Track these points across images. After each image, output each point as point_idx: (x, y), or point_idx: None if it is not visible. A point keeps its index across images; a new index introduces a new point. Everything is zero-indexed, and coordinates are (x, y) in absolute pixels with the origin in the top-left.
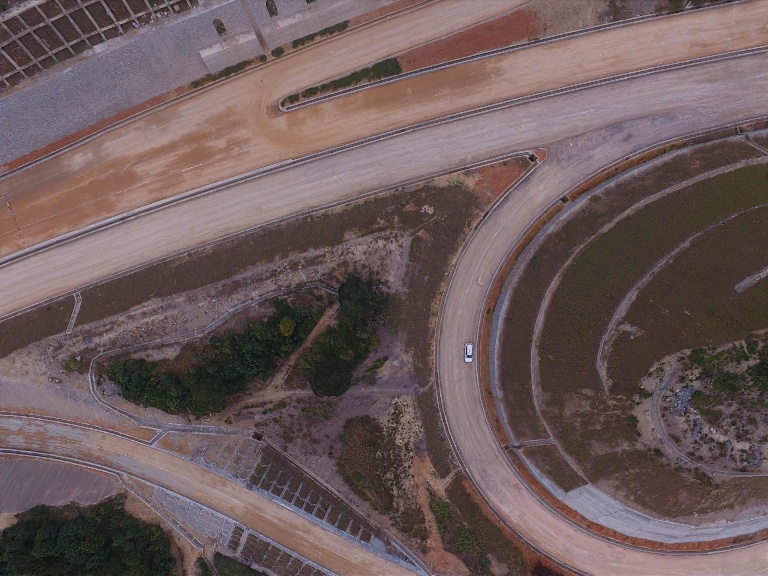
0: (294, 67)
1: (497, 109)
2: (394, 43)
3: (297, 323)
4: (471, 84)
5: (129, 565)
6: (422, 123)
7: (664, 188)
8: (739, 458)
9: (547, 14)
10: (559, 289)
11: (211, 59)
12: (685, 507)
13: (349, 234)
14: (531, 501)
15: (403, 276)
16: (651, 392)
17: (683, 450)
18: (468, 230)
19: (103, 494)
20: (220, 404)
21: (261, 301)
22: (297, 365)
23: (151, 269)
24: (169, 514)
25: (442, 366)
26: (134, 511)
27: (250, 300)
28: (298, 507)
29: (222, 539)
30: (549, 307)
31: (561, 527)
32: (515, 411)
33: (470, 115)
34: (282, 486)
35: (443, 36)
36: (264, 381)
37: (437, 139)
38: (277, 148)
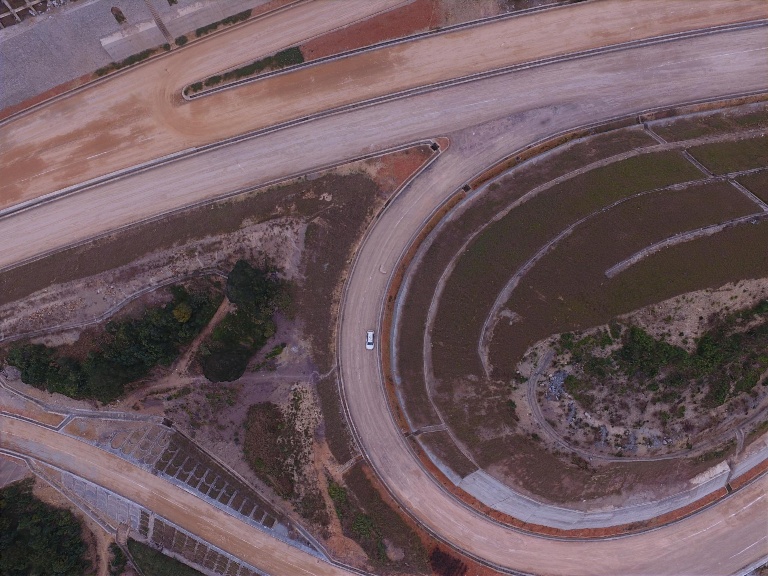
0: (198, 56)
1: (399, 98)
2: (297, 32)
3: (193, 309)
4: (374, 73)
5: (35, 549)
6: (324, 112)
7: (557, 176)
8: (614, 443)
9: (448, 3)
10: (452, 276)
11: (113, 47)
12: (570, 492)
13: (247, 221)
14: (431, 487)
15: (299, 263)
16: (526, 377)
17: (560, 435)
18: (370, 218)
19: (9, 478)
20: (116, 389)
21: (159, 287)
22: (199, 351)
23: (56, 256)
24: (80, 499)
25: (344, 353)
26: (43, 496)
27: (148, 286)
28: (202, 492)
29: (133, 524)
30: (442, 294)
31: (460, 513)
32: (411, 398)
33: (372, 104)
34: (188, 472)
35: (345, 25)
36: (167, 367)
37: (340, 128)
38: (181, 136)
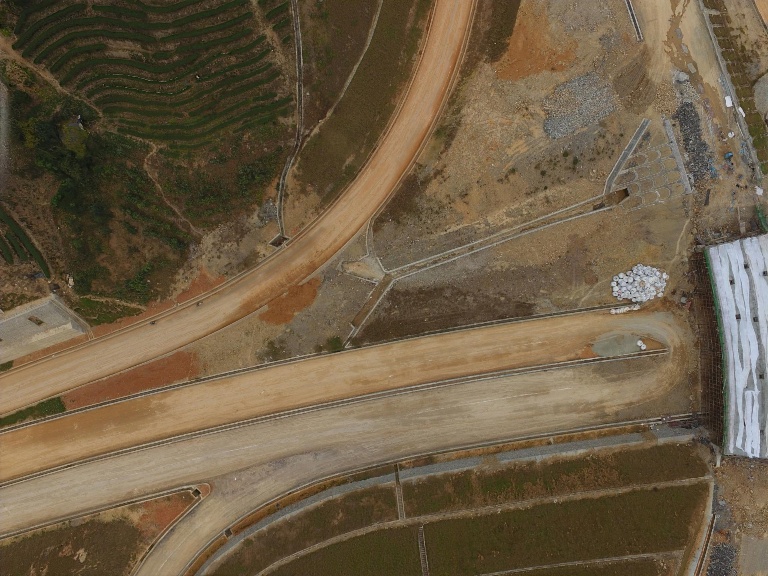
0: None
1: (161, 445)
2: (58, 382)
3: None
4: (136, 420)
5: None
6: (87, 459)
7: (298, 550)
8: None
9: (206, 355)
10: None
11: None
12: None
13: None
14: None
15: None
16: None
17: None
18: (133, 563)
19: None
20: None
21: None
22: None
23: None
24: None
25: None
26: None
27: None
28: None
29: None
30: None
31: None
32: None
33: (134, 451)
34: None
35: (104, 377)
36: None
37: (104, 473)
38: None
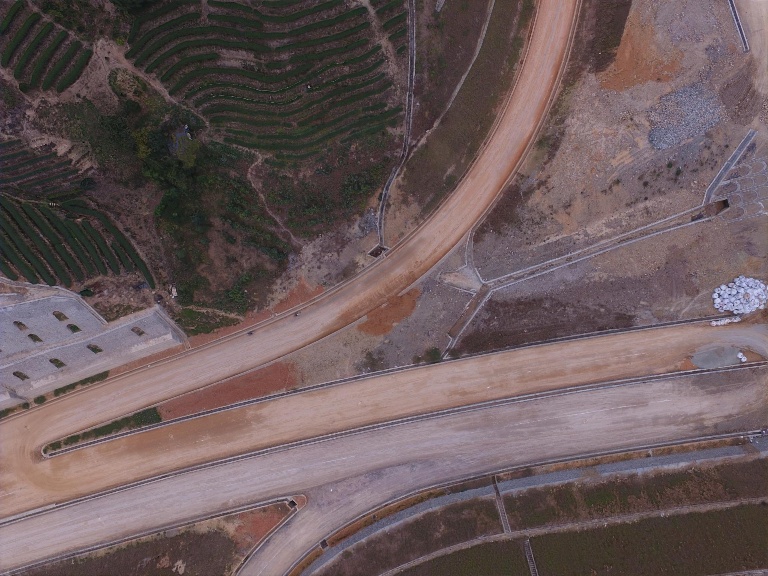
0: (57, 413)
1: (257, 456)
2: (154, 392)
3: None
4: (232, 431)
5: None
6: (182, 470)
7: (402, 563)
8: None
9: (304, 366)
10: None
11: None
12: None
13: None
14: None
15: None
16: None
17: None
18: (228, 574)
19: None
20: None
21: None
22: None
23: None
24: None
25: None
26: None
27: None
28: None
29: None
30: None
31: None
32: None
33: (230, 462)
34: None
35: (201, 388)
36: None
37: (199, 483)
38: (42, 491)
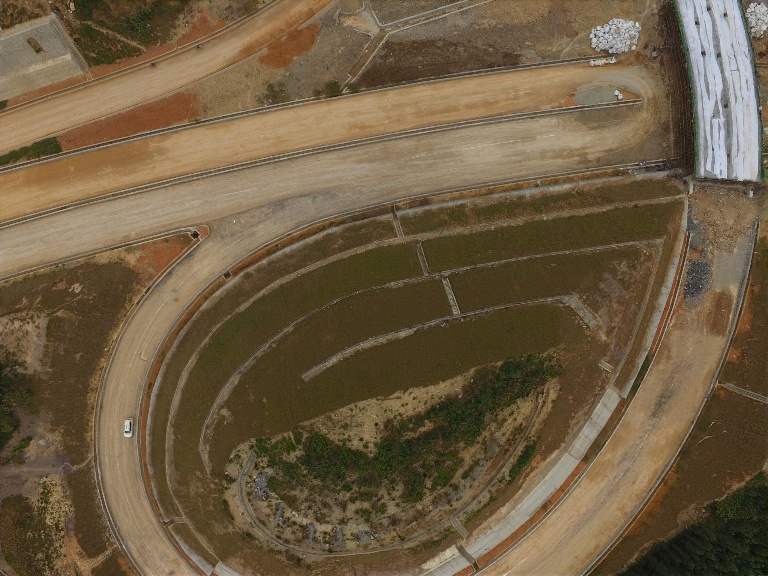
0: None
1: (159, 187)
2: (54, 122)
3: None
4: (134, 163)
5: None
6: (83, 201)
7: (299, 268)
8: (322, 540)
9: (206, 97)
10: (194, 368)
11: None
12: None
13: None
14: (190, 575)
15: (41, 356)
16: (235, 478)
17: (272, 533)
18: (129, 306)
19: None
20: None
21: None
22: None
23: None
24: None
25: (102, 442)
26: None
27: None
28: None
29: None
30: (185, 386)
31: None
32: (161, 488)
33: (132, 193)
34: None
35: (102, 117)
36: None
37: (100, 216)
38: None
